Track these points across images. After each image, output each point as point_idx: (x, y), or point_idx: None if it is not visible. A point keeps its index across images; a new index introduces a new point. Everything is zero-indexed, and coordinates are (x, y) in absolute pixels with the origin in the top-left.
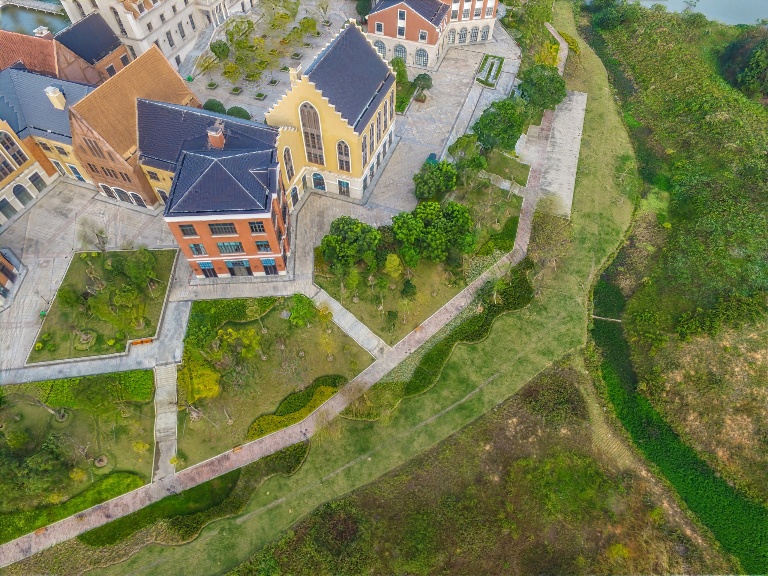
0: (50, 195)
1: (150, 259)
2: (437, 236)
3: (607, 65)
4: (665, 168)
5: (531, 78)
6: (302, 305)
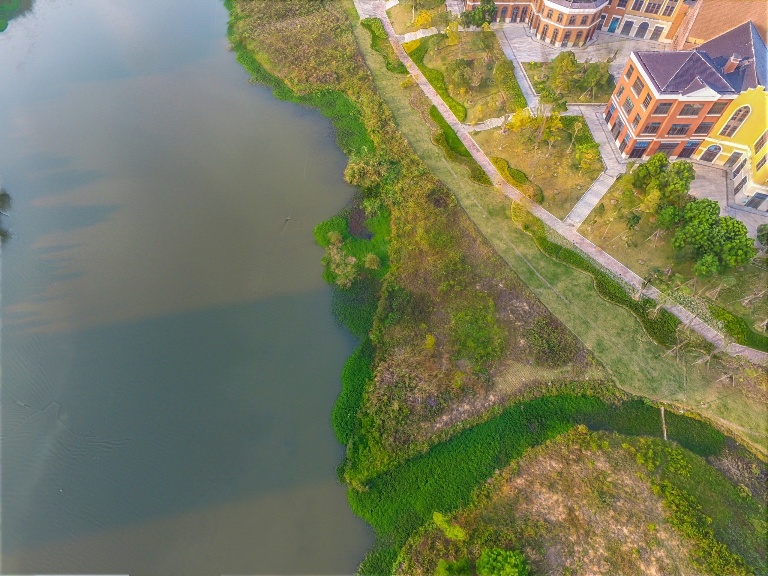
0: (649, 44)
1: (604, 76)
2: (699, 229)
3: None
4: None
5: None
6: (590, 147)
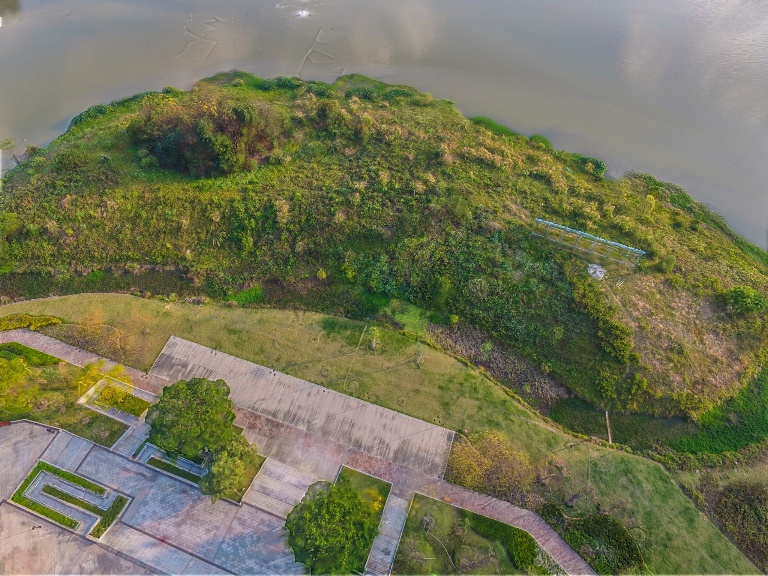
0: None
1: None
2: None
3: (102, 288)
4: (348, 288)
5: (184, 437)
6: None
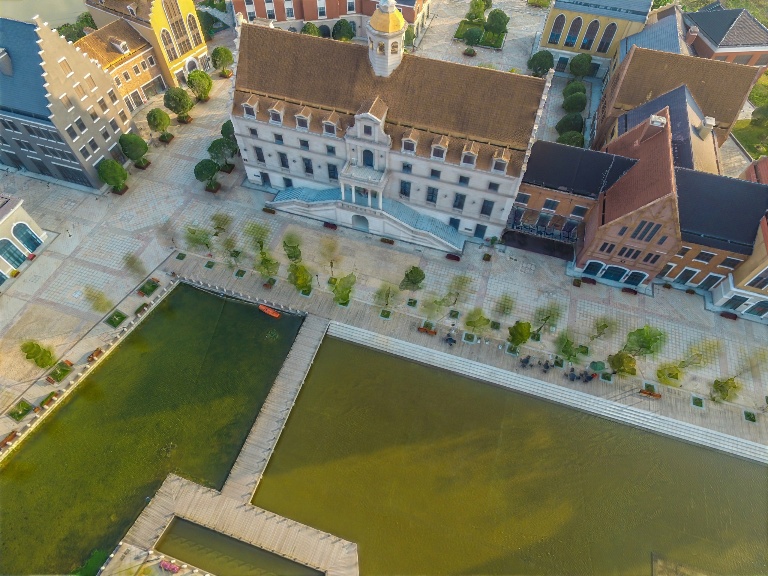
0: None
1: None
2: None
3: None
4: None
5: None
6: None
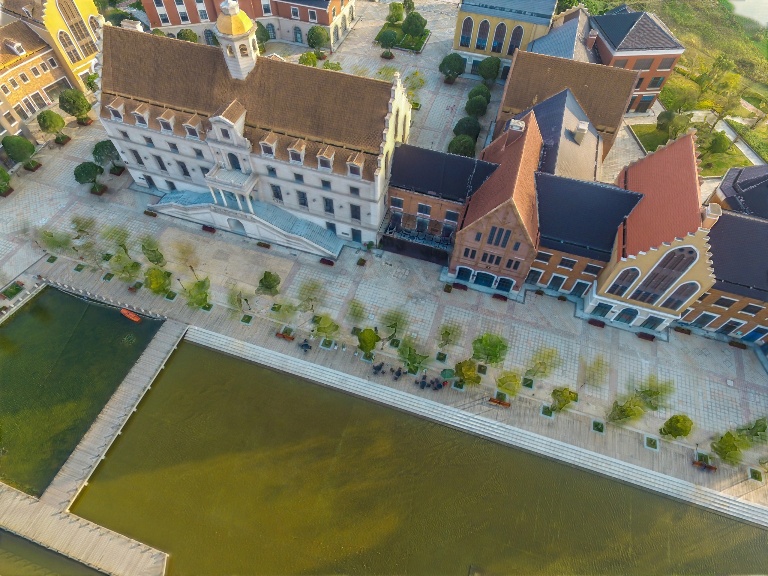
0: None
1: None
2: None
3: None
4: None
5: None
6: None
